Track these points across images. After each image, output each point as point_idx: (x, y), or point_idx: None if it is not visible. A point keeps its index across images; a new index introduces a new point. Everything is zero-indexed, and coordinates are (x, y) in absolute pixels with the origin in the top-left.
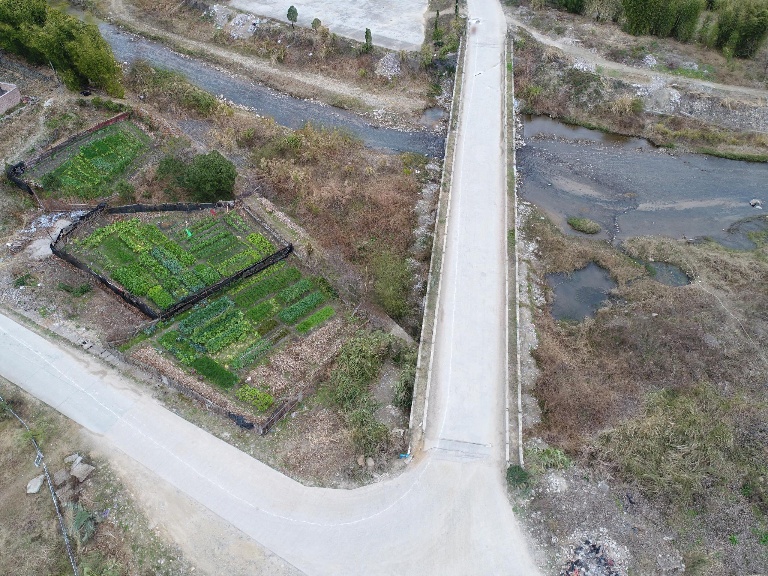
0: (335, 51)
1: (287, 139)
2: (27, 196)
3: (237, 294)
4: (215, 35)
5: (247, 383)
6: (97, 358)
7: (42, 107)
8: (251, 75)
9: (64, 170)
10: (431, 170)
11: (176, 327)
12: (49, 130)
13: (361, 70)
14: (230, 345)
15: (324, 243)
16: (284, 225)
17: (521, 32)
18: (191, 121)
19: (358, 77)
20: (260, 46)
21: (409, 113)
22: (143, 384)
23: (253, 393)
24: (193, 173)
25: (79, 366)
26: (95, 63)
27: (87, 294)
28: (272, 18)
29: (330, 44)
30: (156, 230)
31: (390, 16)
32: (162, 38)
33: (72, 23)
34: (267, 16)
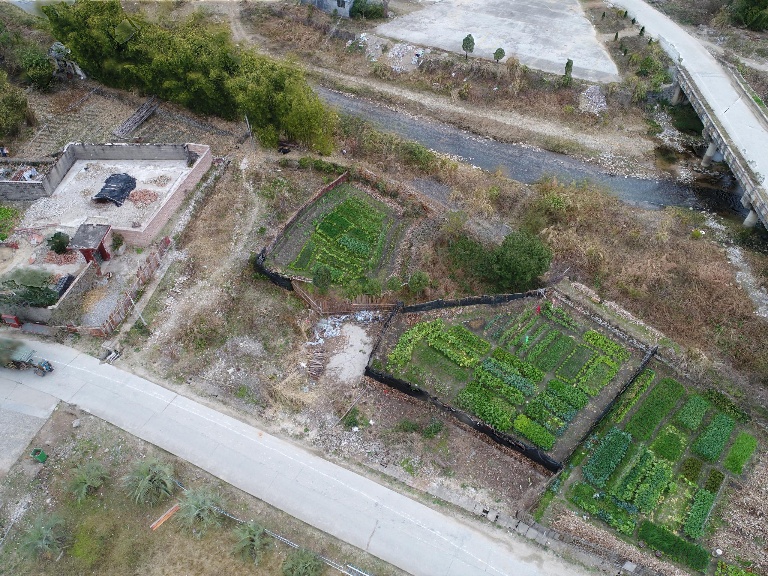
0: (528, 85)
1: (552, 201)
2: (287, 293)
3: (622, 421)
4: (374, 69)
5: (718, 558)
6: (515, 534)
7: (240, 170)
8: (436, 116)
9: (310, 254)
10: (716, 229)
11: (577, 476)
12: (265, 201)
13: (568, 107)
14: (660, 499)
15: (681, 341)
16: (625, 320)
17: (726, 56)
18: (420, 180)
19: (564, 115)
20: (433, 81)
21: (640, 156)
22: (600, 573)
23: (739, 574)
24: (515, 262)
25: (500, 549)
26: (308, 117)
27: (441, 433)
28: (434, 47)
29: (520, 77)
30: (470, 333)
31: (562, 40)
32: (312, 74)
33: (283, 72)
34: (427, 45)
